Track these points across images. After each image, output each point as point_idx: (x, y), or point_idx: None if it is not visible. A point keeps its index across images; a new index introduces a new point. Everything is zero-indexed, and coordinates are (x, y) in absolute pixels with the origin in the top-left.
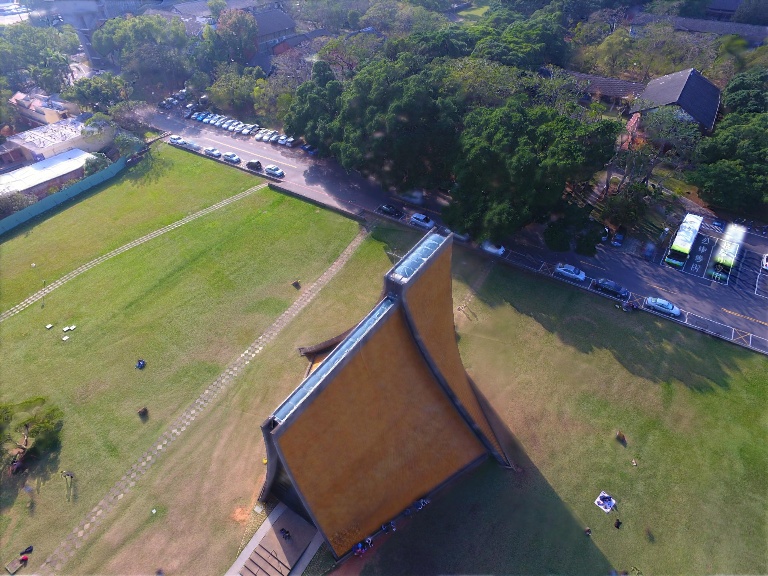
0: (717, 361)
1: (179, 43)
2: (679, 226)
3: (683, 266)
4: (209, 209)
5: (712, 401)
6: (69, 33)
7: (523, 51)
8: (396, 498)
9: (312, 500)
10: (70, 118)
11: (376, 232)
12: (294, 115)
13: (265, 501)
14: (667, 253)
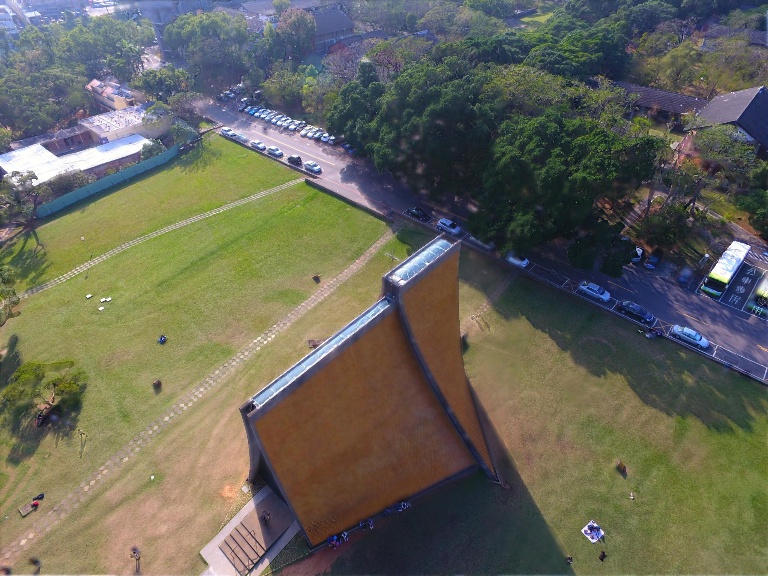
0: (742, 401)
1: (240, 40)
2: None
3: (721, 296)
4: (247, 199)
5: (729, 442)
6: (147, 27)
7: (578, 60)
8: (377, 497)
9: (289, 486)
10: (135, 106)
11: (401, 234)
12: None
13: (253, 482)
14: None
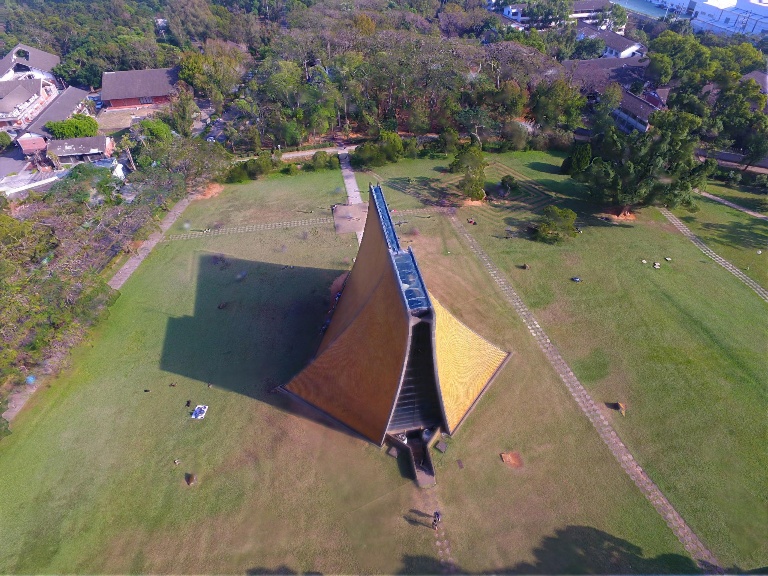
0: None
1: None
2: None
3: None
4: None
5: None
6: None
7: None
8: None
9: None
10: None
11: (693, 571)
12: None
13: None
14: None
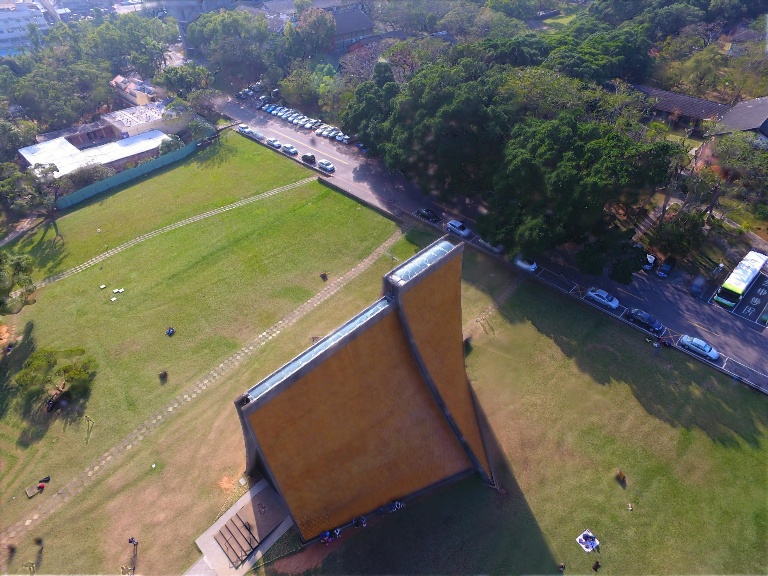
0: (751, 415)
1: (261, 38)
2: None
3: (734, 307)
4: (260, 196)
5: (735, 457)
6: (171, 24)
7: (598, 63)
8: (371, 495)
9: (282, 480)
10: (157, 102)
11: (411, 234)
12: None
13: (250, 475)
14: None
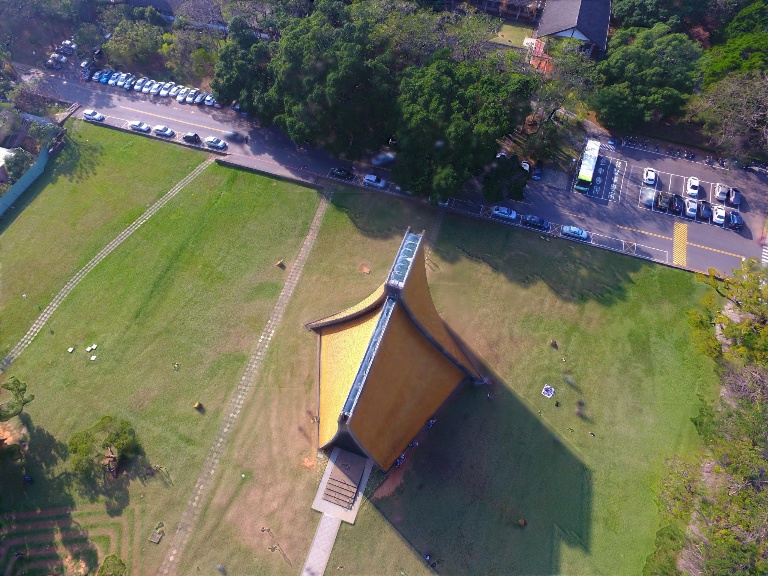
0: (613, 271)
1: None
2: (583, 150)
3: (587, 190)
4: (166, 197)
5: (611, 303)
6: None
7: None
8: (415, 425)
9: (368, 447)
10: None
11: (335, 198)
12: (220, 79)
13: (323, 449)
14: (575, 180)
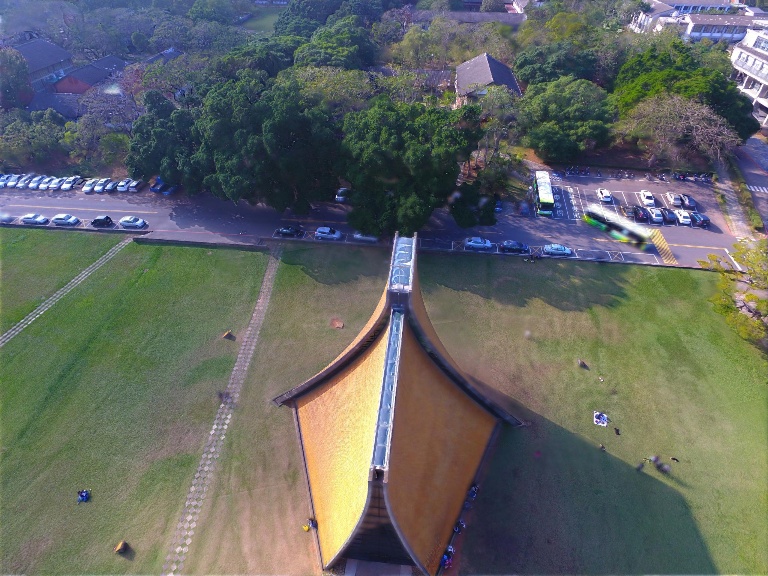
0: (611, 280)
1: None
2: (532, 183)
3: (552, 214)
4: (68, 286)
5: (623, 311)
6: None
7: (342, 55)
8: (455, 497)
9: (408, 535)
10: None
11: (286, 257)
12: (135, 155)
13: (331, 567)
14: (536, 207)
